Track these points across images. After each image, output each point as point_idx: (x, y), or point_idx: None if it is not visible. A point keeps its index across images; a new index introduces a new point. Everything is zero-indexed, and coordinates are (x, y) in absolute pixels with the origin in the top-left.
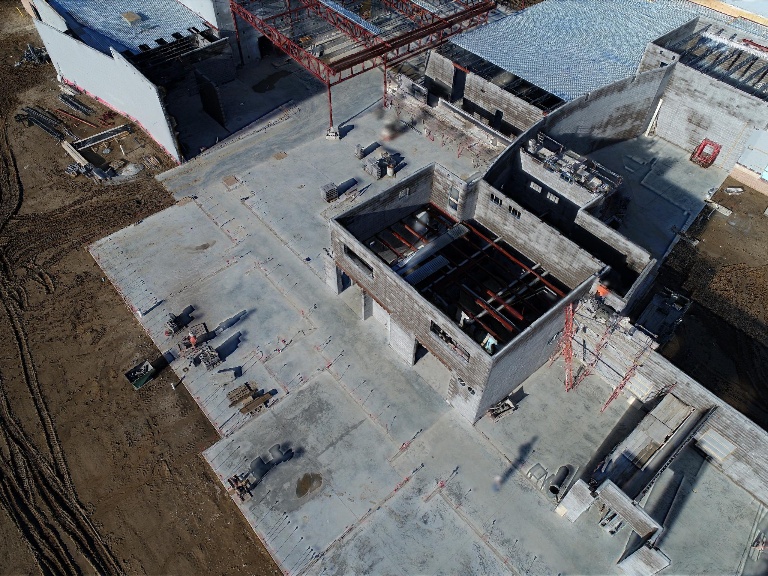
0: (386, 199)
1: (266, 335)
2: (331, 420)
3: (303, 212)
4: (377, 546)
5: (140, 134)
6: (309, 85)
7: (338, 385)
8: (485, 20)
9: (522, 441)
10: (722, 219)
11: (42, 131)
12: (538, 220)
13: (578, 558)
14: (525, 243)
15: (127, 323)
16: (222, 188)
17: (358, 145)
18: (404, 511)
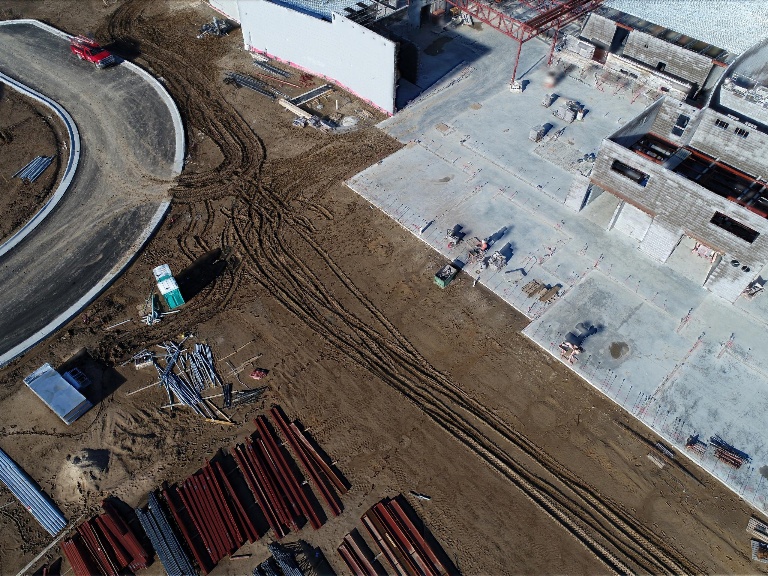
0: (633, 125)
1: (532, 244)
2: (616, 304)
3: (518, 150)
4: (694, 389)
5: (342, 92)
6: (473, 48)
7: (610, 279)
8: None
9: None
10: None
11: (253, 92)
12: None
13: None
14: (747, 160)
15: (409, 240)
16: (438, 133)
17: (547, 95)
18: (704, 365)
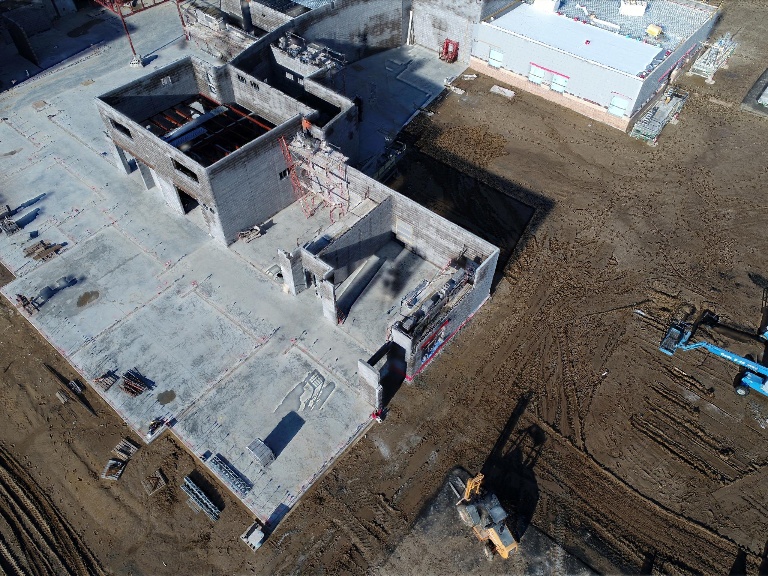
0: (148, 84)
1: (62, 208)
2: (111, 257)
3: None
4: (139, 328)
5: None
6: (120, 28)
7: (120, 234)
8: None
9: (266, 253)
10: (456, 97)
11: None
12: (268, 87)
13: (295, 316)
14: (269, 111)
15: None
16: (32, 110)
17: (155, 67)
18: (164, 305)
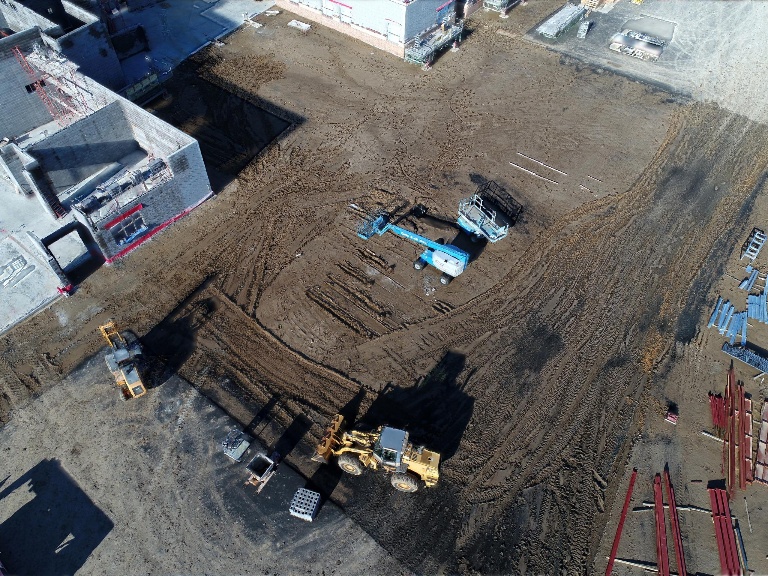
0: None
1: None
2: None
3: None
4: None
5: None
6: None
7: None
8: None
9: None
10: (253, 30)
11: None
12: (21, 6)
13: (19, 213)
14: None
15: None
16: None
17: None
18: None
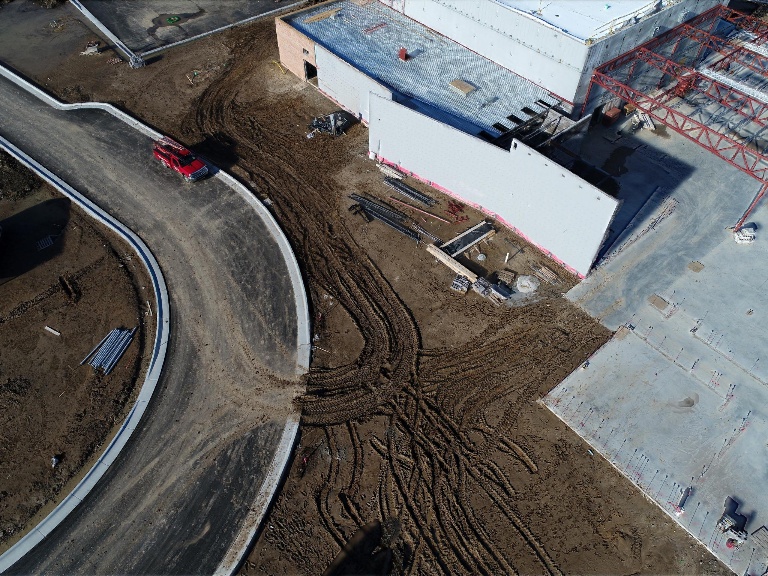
0: None
1: None
2: None
3: None
4: None
5: (507, 233)
6: (666, 167)
7: None
8: None
9: None
10: None
11: (389, 228)
12: None
13: None
14: None
15: (660, 523)
16: (656, 313)
17: None
18: None
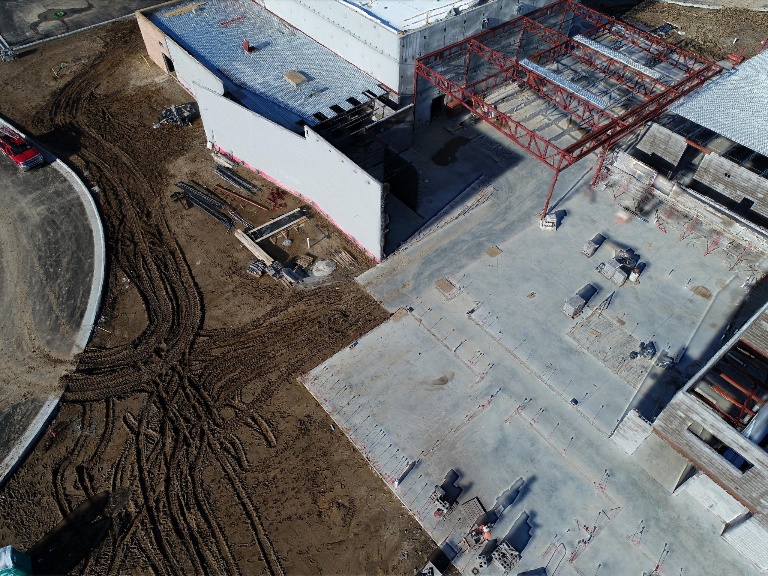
0: None
1: (560, 517)
2: None
3: (546, 332)
4: None
5: (320, 220)
6: (496, 156)
7: None
8: (702, 83)
9: None
10: None
11: (206, 214)
12: None
13: None
14: None
15: (379, 494)
16: (439, 296)
17: (589, 242)
18: None
